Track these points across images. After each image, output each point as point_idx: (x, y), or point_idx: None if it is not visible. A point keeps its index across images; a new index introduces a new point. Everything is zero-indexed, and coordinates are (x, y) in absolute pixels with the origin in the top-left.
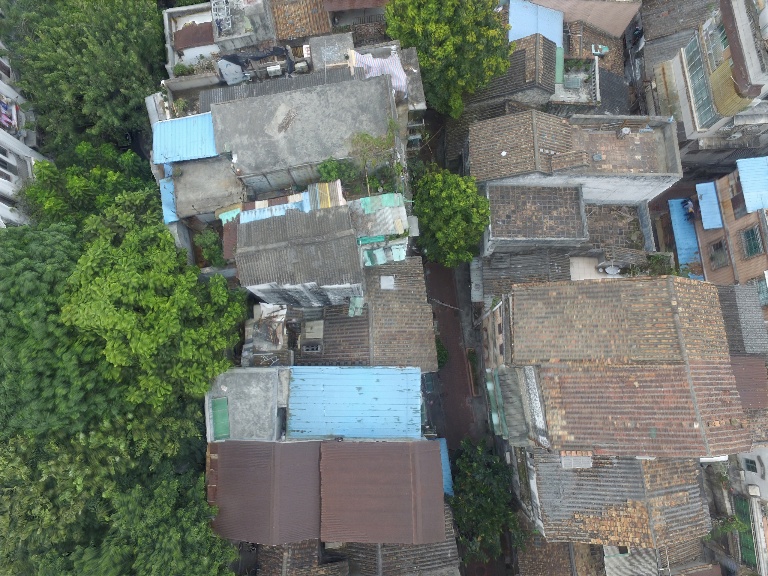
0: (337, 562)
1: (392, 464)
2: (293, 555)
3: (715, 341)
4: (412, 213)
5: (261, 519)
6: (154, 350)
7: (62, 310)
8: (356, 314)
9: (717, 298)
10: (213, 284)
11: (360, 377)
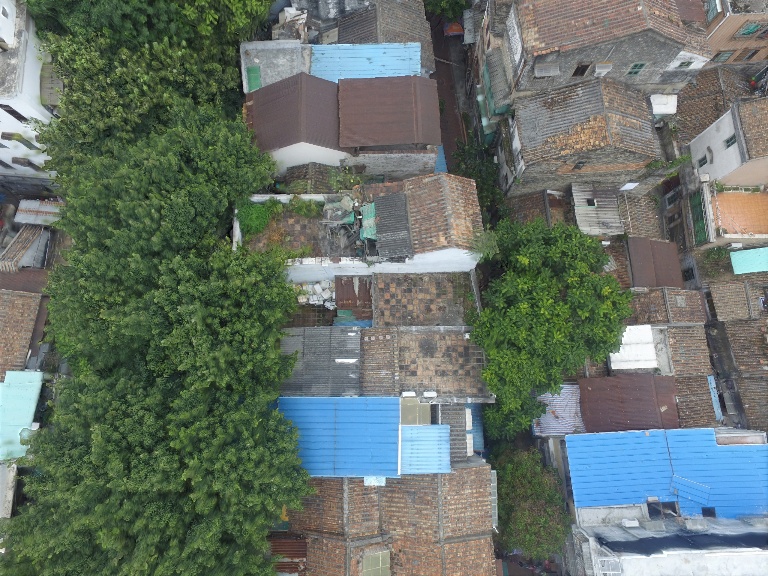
0: None
1: (397, 91)
2: (316, 184)
3: None
4: None
5: (291, 128)
6: None
7: None
8: None
9: None
10: None
11: (370, 51)
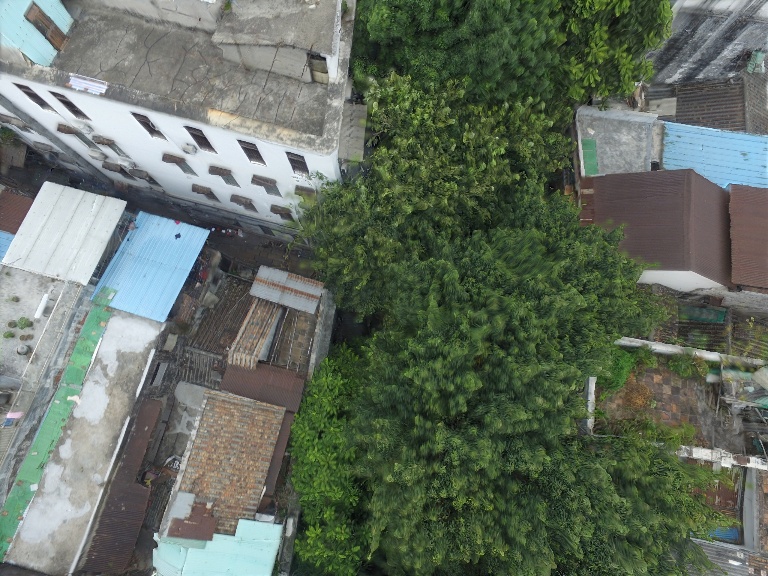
0: (687, 342)
1: None
2: None
3: None
4: None
5: (669, 246)
6: (627, 8)
7: None
8: (755, 71)
9: None
10: None
11: (745, 143)
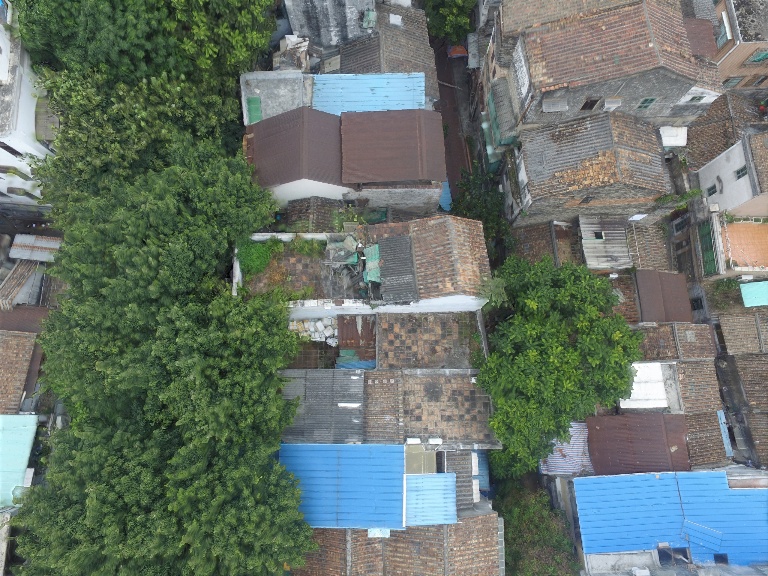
0: None
1: (401, 125)
2: (317, 219)
3: (670, 1)
4: (416, 1)
5: (292, 164)
6: None
7: None
8: (369, 26)
9: None
10: None
11: (373, 81)
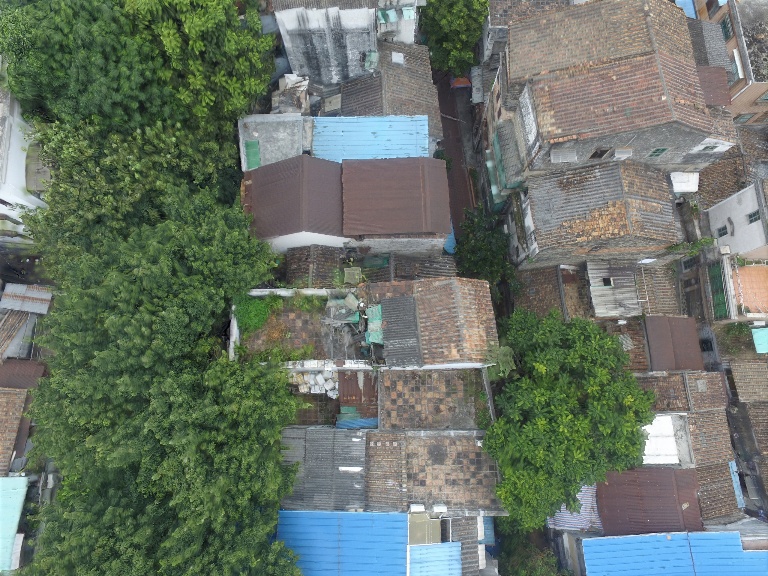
0: (355, 285)
1: (404, 174)
2: (318, 268)
3: (682, 49)
4: (418, 32)
5: (292, 215)
6: (202, 46)
7: (126, 0)
8: (371, 67)
9: (685, 19)
10: (249, 16)
11: (375, 124)
